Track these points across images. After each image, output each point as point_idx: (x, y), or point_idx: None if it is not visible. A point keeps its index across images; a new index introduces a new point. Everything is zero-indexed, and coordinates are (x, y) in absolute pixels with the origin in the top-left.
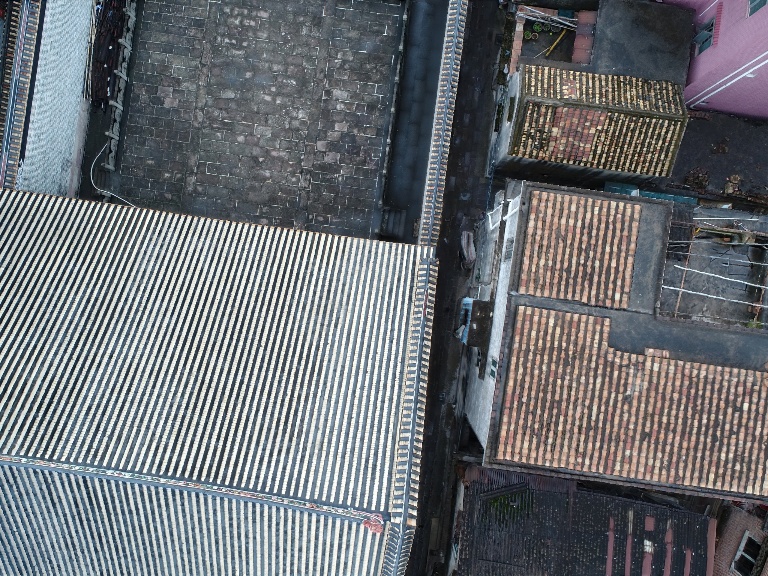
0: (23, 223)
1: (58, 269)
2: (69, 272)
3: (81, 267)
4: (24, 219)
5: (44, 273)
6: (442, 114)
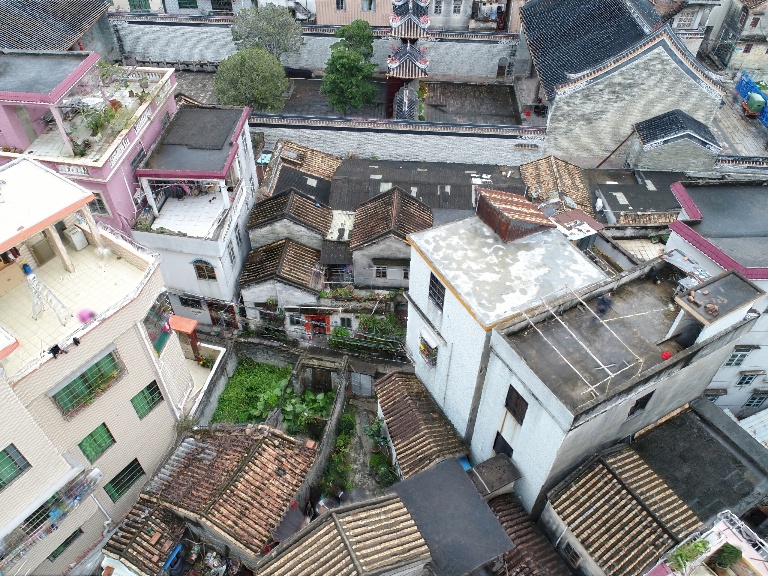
0: (86, 5)
1: (57, 3)
2: (54, 5)
3: (56, 8)
4: (88, 6)
5: (57, 0)
6: None
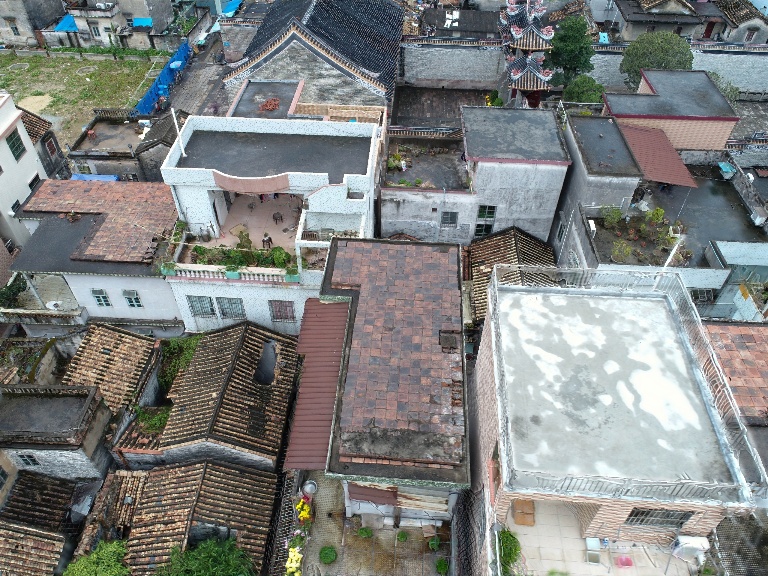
0: None
1: None
2: None
3: None
4: None
5: None
6: (764, 48)
